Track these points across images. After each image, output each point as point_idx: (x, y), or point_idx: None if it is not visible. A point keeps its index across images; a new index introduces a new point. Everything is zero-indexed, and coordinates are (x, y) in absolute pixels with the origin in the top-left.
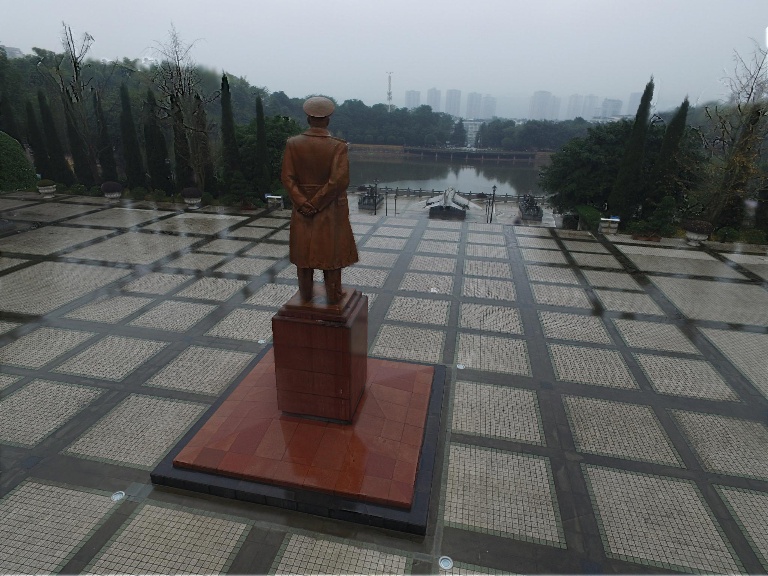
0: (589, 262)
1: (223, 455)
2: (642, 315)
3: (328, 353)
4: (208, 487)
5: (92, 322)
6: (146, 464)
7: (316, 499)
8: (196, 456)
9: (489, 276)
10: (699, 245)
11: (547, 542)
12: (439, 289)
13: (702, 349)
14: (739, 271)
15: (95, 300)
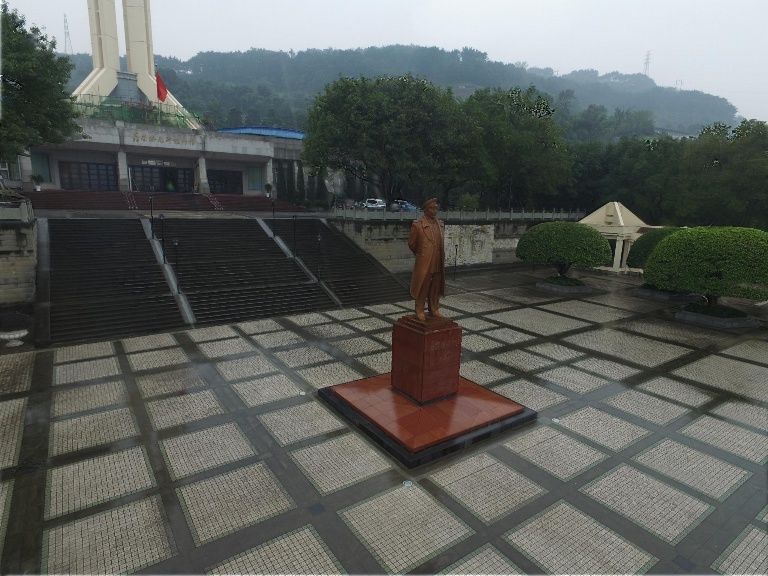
0: None
1: None
2: None
3: None
4: None
5: None
6: None
7: None
8: None
9: None
10: None
11: None
12: None
13: None
14: None
15: (701, 389)
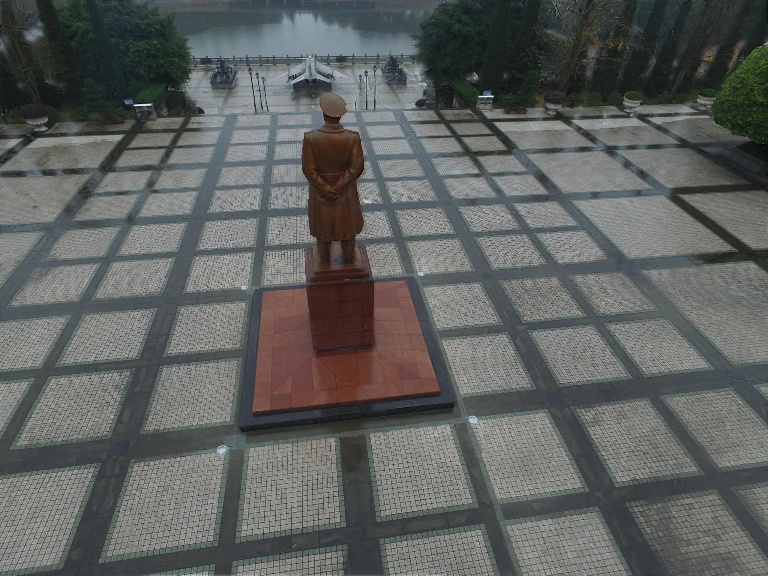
0: (480, 147)
1: (290, 396)
2: (533, 196)
3: (356, 302)
4: (291, 422)
5: (51, 304)
6: (225, 420)
7: (375, 407)
8: (269, 403)
9: (406, 176)
10: (556, 113)
11: (525, 388)
12: (370, 199)
13: (578, 220)
14: (588, 138)
15: (30, 278)
